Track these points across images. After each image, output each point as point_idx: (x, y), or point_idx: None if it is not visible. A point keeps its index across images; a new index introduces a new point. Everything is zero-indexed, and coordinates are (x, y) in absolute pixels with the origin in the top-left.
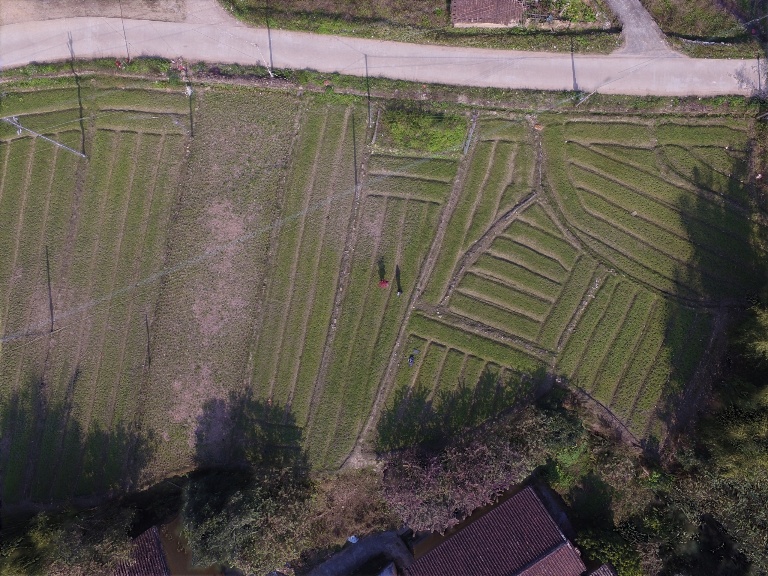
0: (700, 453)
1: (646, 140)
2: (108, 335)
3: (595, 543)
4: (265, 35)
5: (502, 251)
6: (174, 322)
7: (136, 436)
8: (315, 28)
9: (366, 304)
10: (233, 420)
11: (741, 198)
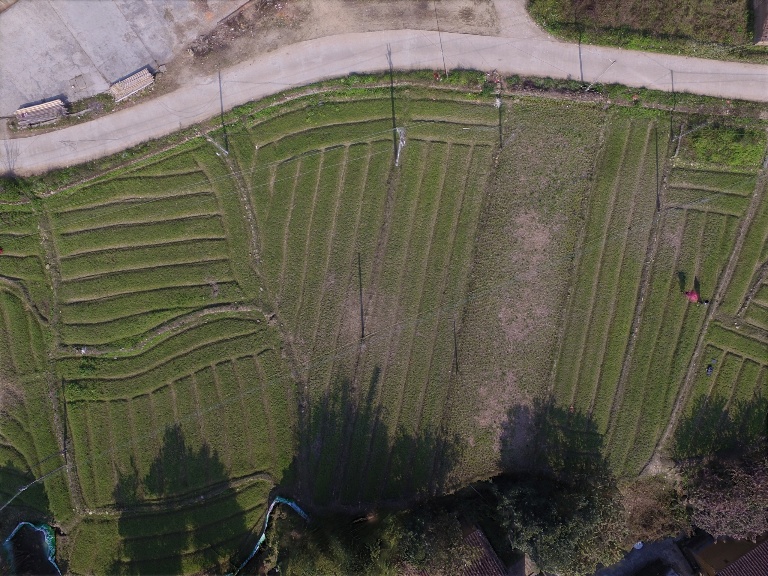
0: None
1: None
2: (417, 341)
3: None
4: (576, 50)
5: None
6: (481, 329)
7: (443, 441)
8: (625, 44)
9: (666, 314)
10: (537, 426)
11: None
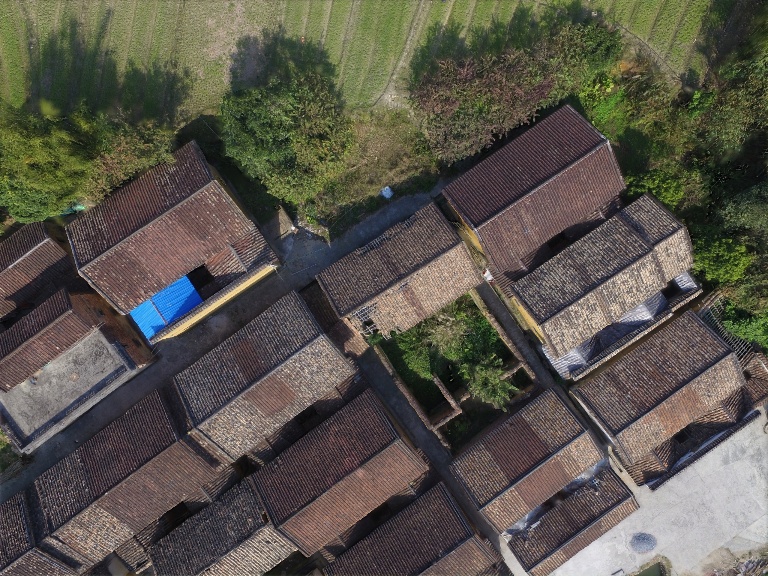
0: (744, 59)
1: None
2: None
3: (634, 177)
4: None
5: None
6: None
7: (172, 74)
8: None
9: None
10: (267, 57)
11: None
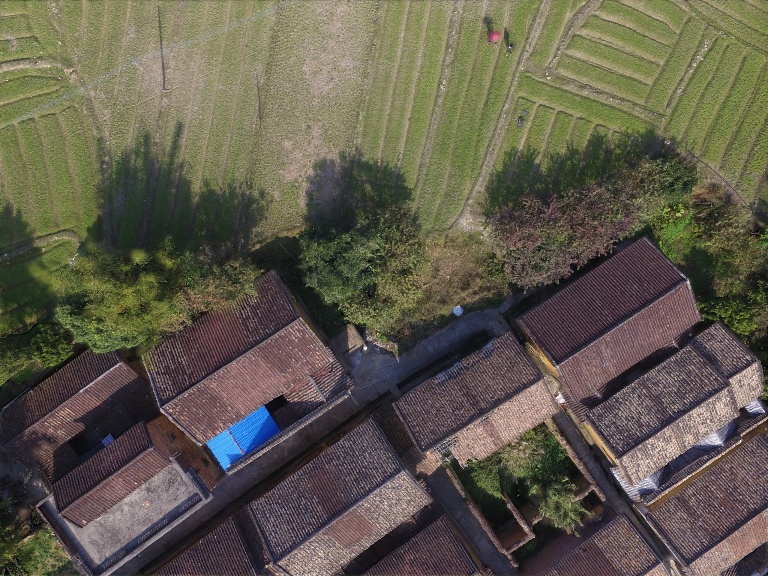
0: None
1: None
2: (219, 95)
3: (705, 304)
4: None
5: (610, 13)
6: (284, 82)
7: (247, 195)
8: None
9: (475, 65)
10: (343, 180)
11: None
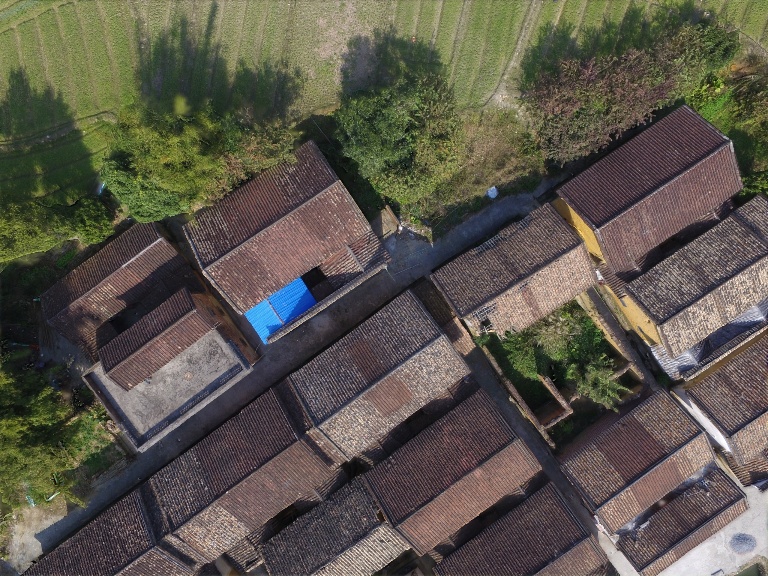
0: None
1: None
2: None
3: (746, 178)
4: None
5: None
6: None
7: (283, 74)
8: None
9: None
10: (378, 57)
11: None
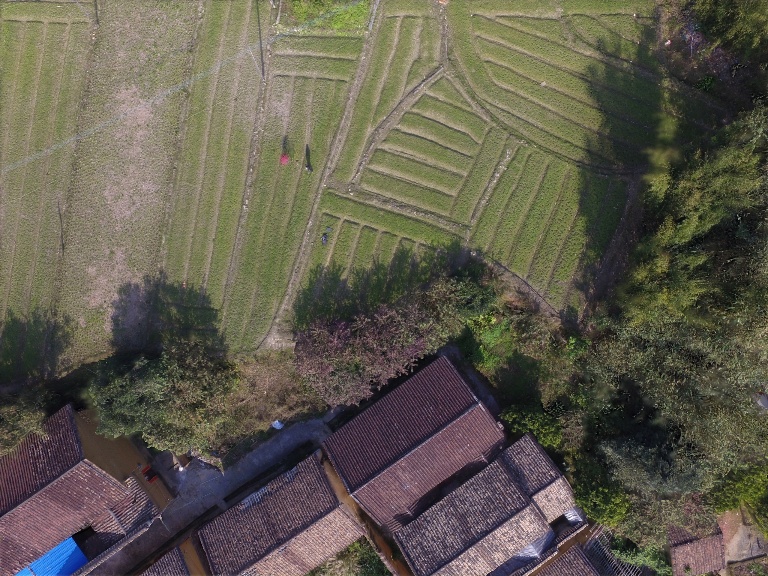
0: (613, 312)
1: (552, 10)
2: (21, 224)
3: (516, 415)
4: None
5: (411, 126)
6: (86, 209)
7: (52, 323)
8: None
9: (277, 184)
10: (148, 304)
11: (651, 64)
